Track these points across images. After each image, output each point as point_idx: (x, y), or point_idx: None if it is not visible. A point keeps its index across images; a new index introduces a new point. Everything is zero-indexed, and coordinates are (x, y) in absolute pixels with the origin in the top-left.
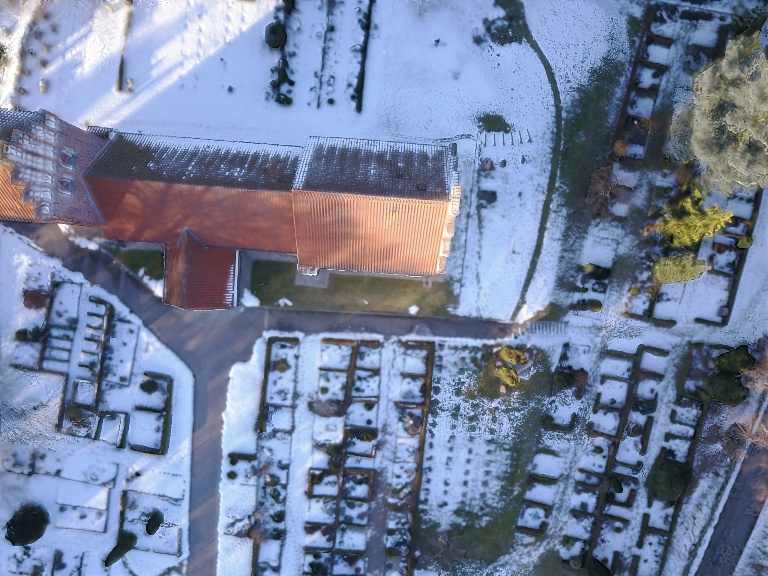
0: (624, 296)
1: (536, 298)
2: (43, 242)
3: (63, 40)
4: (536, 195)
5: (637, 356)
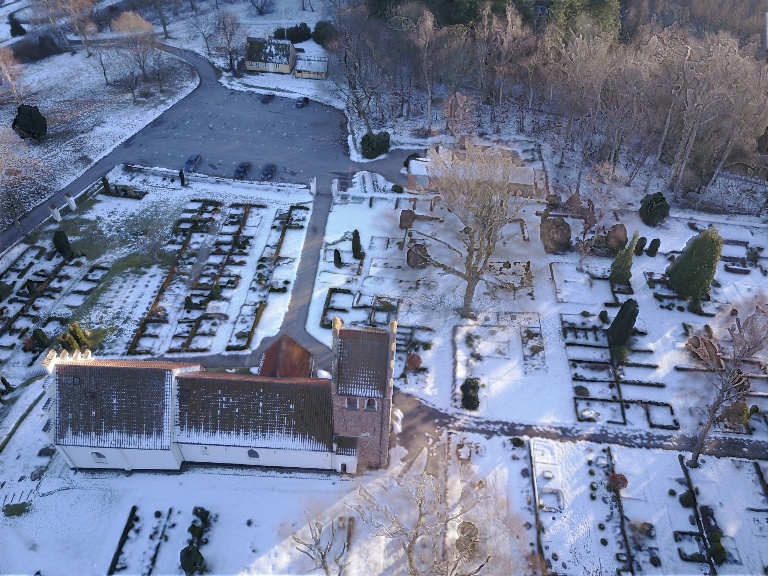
0: None
1: (38, 387)
2: (415, 403)
3: None
4: (4, 459)
5: None
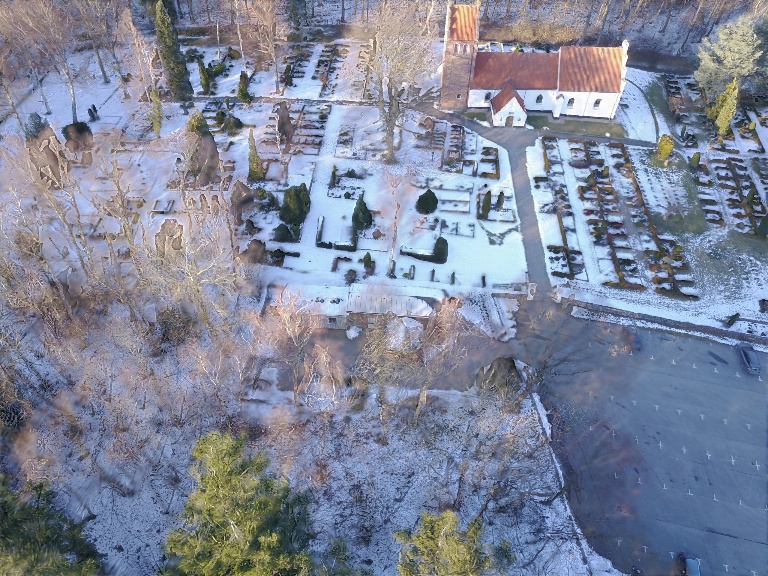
0: (707, 144)
1: None
2: (427, 112)
3: None
4: (646, 109)
5: None
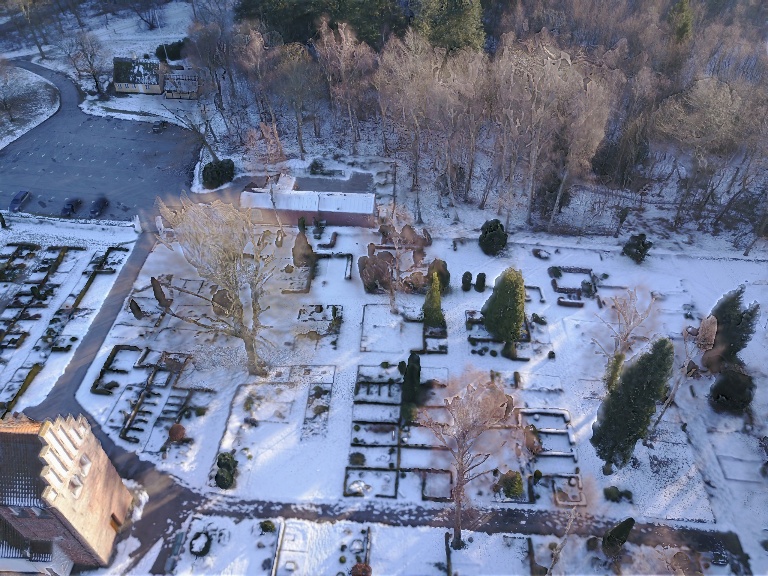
0: None
1: None
2: (167, 482)
3: None
4: None
5: None
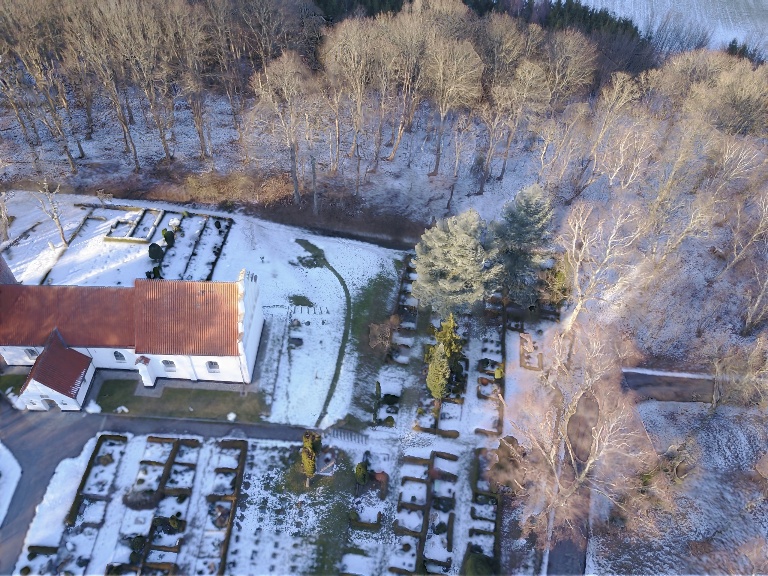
0: (413, 416)
1: (336, 410)
2: None
3: (14, 264)
4: (334, 343)
5: (429, 459)
